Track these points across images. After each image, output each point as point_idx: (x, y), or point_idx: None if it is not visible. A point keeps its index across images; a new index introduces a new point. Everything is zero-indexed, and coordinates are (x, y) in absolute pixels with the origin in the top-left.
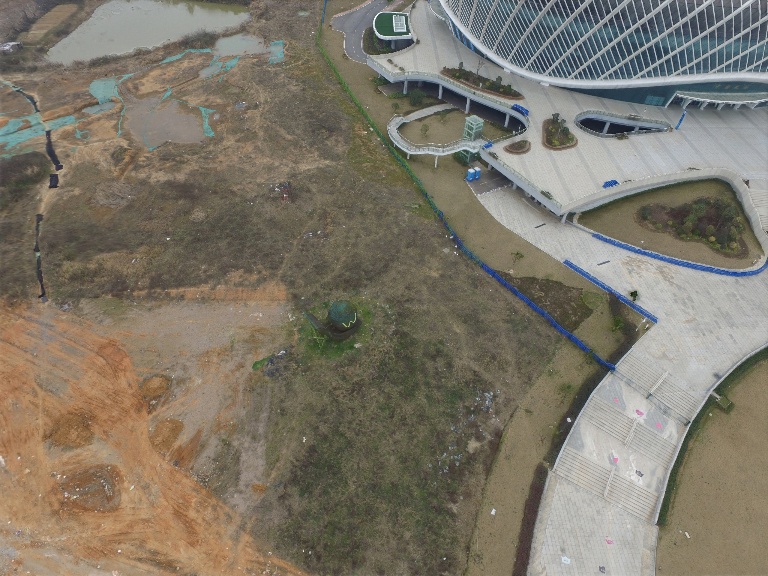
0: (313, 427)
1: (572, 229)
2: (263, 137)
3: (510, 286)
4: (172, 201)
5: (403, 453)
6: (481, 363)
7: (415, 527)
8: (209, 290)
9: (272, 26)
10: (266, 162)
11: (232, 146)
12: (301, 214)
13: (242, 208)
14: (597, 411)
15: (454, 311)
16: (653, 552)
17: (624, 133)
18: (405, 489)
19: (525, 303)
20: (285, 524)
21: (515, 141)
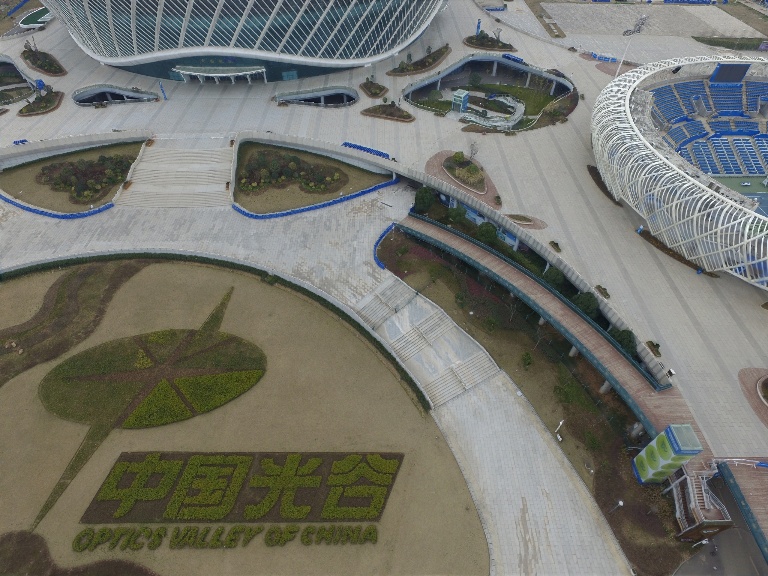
0: None
1: None
2: None
3: None
4: None
5: None
6: None
7: None
8: None
9: None
10: None
11: None
12: None
13: None
14: None
15: None
16: None
17: (101, 102)
18: None
19: None
20: None
21: None
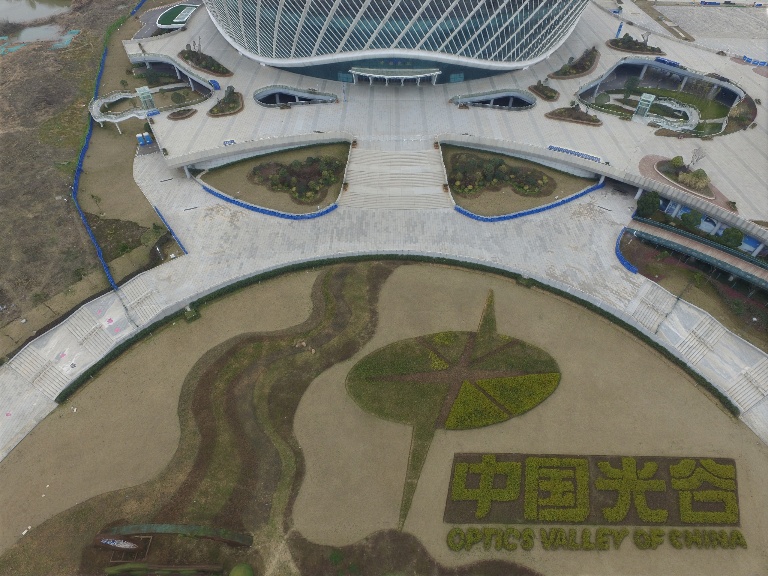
0: None
1: (191, 183)
2: None
3: None
4: None
5: None
6: (12, 283)
7: None
8: None
9: (81, 18)
10: None
11: None
12: None
13: None
14: (78, 320)
15: (22, 244)
16: (38, 422)
17: (286, 103)
18: None
19: (91, 239)
20: None
21: None
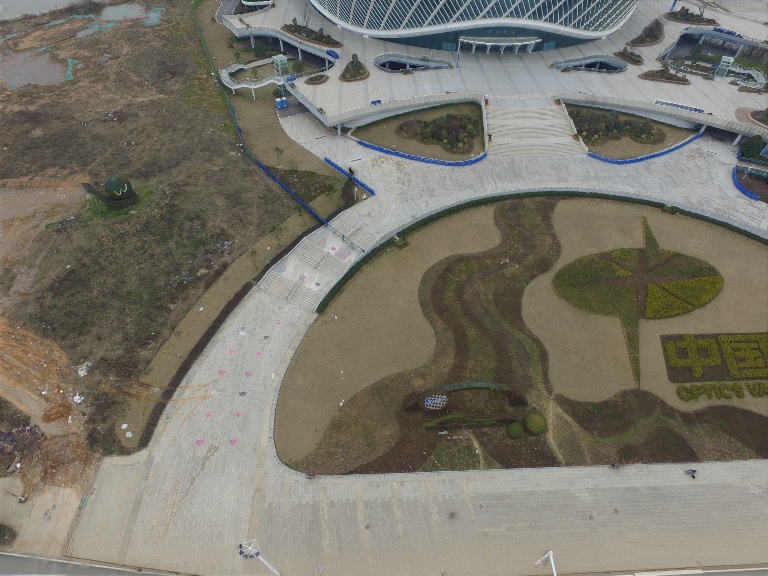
0: (78, 259)
1: (344, 139)
2: (114, 79)
3: (272, 174)
4: (19, 124)
5: (143, 275)
6: (229, 223)
7: (137, 316)
8: (27, 180)
9: None
10: (109, 97)
11: (84, 86)
12: (123, 131)
13: (76, 128)
14: (304, 249)
15: (221, 191)
16: (308, 328)
17: (409, 69)
18: (137, 295)
19: (280, 186)
20: (35, 312)
21: None
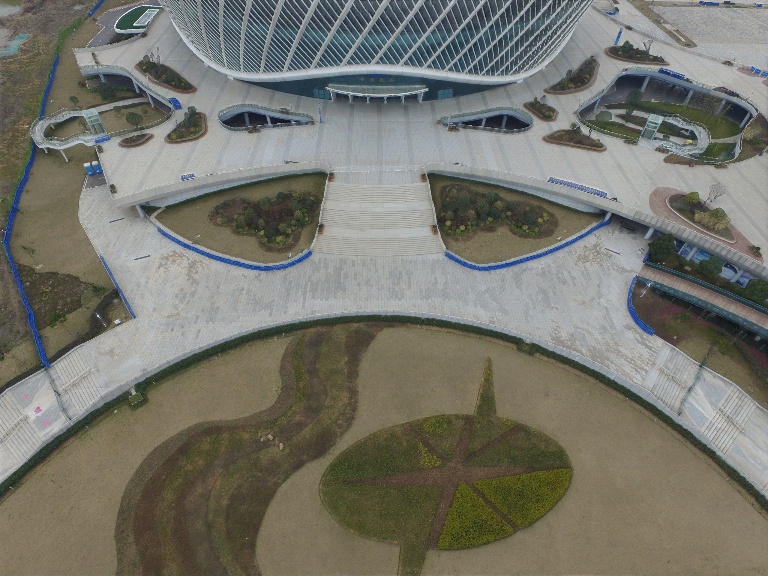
0: None
1: (145, 223)
2: None
3: (17, 281)
4: None
5: None
6: None
7: None
8: None
9: (32, 20)
10: None
11: None
12: None
13: None
14: None
15: None
16: None
17: (255, 126)
18: None
19: None
20: None
21: (139, 134)
